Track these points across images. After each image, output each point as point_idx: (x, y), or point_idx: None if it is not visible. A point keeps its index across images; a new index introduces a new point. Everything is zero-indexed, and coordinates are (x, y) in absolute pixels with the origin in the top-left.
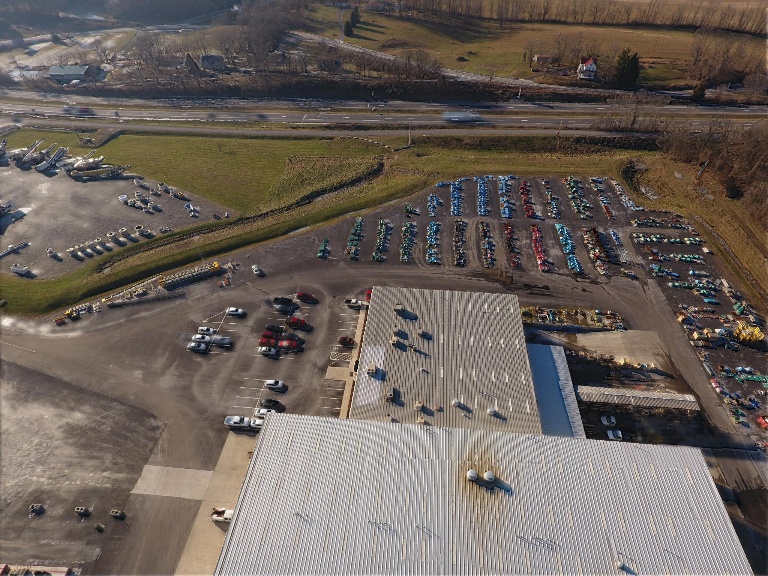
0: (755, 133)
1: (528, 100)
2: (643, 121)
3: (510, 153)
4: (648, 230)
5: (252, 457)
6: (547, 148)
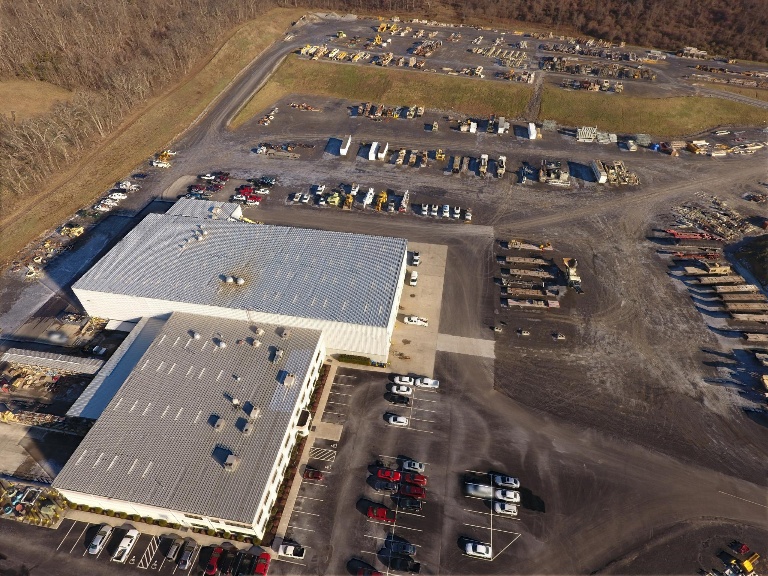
0: None
1: None
2: None
3: None
4: None
5: (393, 300)
6: None
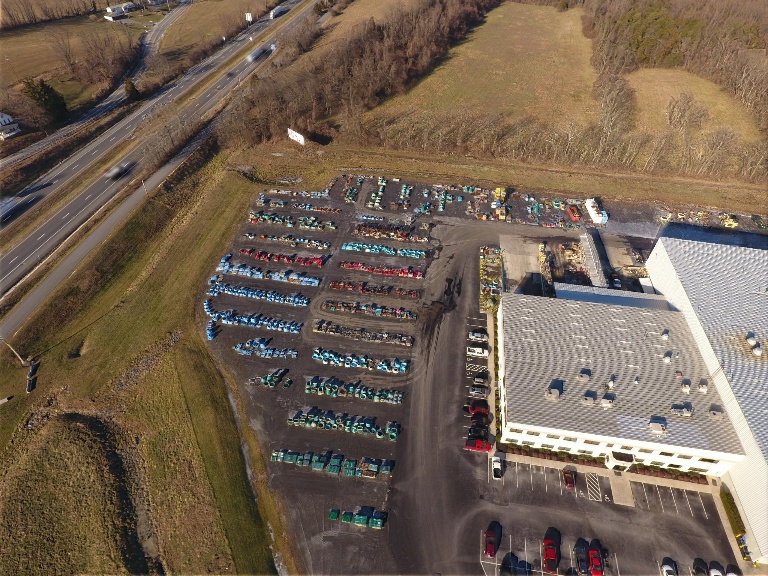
0: (269, 94)
1: (5, 197)
2: (176, 135)
3: (147, 250)
4: (362, 197)
5: None
6: (163, 216)
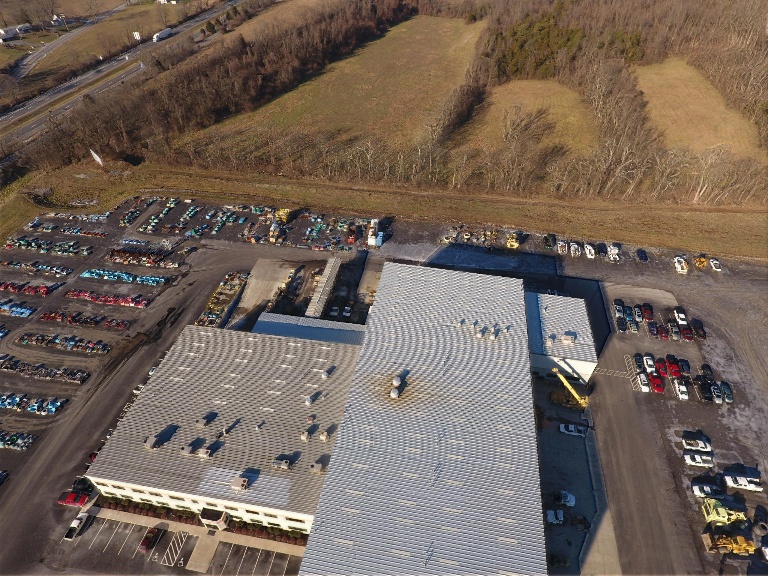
0: (85, 114)
1: None
2: None
3: None
4: (140, 220)
5: None
6: None
